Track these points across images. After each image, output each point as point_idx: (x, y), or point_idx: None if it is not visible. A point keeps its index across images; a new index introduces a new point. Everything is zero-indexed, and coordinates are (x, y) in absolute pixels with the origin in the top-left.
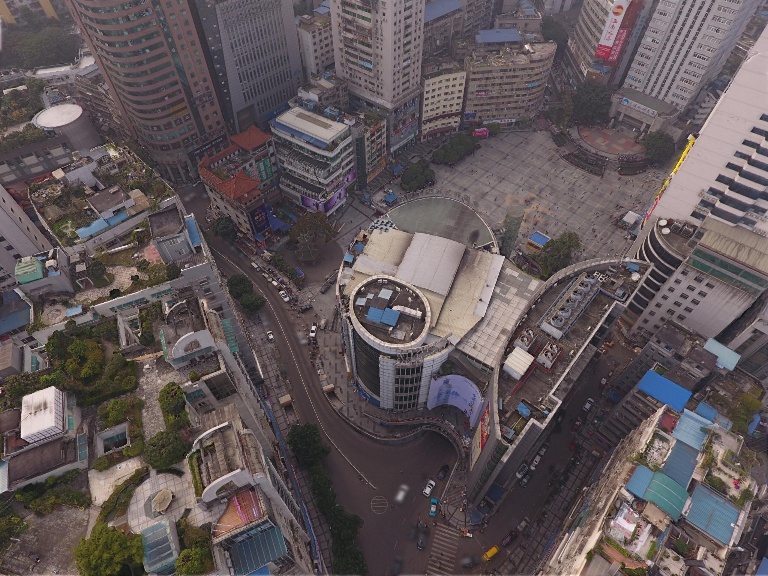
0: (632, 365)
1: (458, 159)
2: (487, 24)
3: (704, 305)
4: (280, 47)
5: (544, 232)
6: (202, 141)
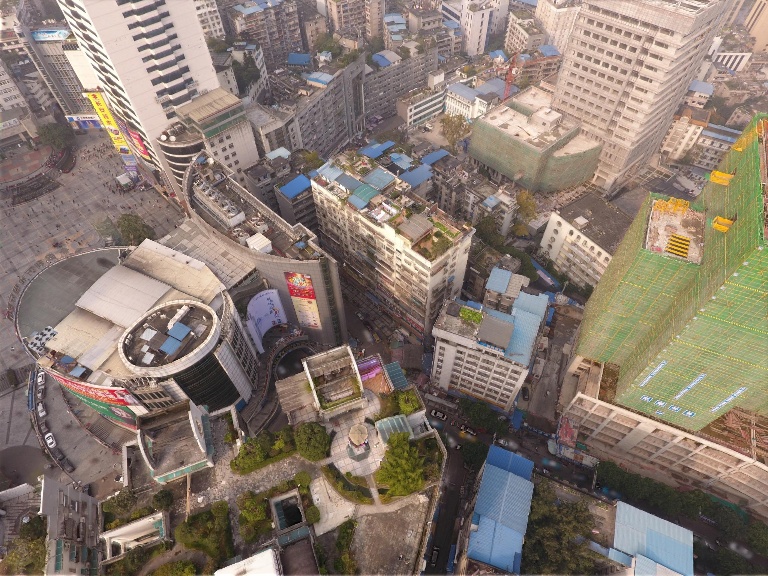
0: None
1: None
2: None
3: (238, 151)
4: None
5: None
6: None
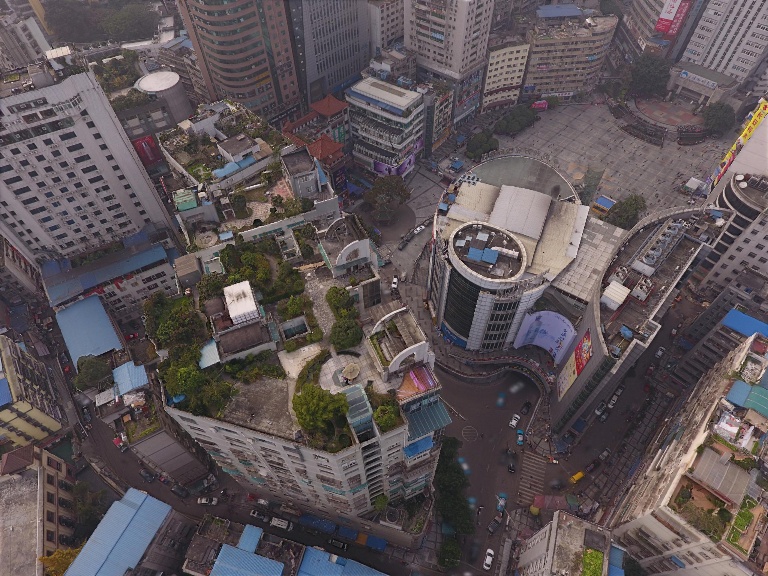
0: (708, 312)
1: (519, 130)
2: (543, 1)
3: None
4: (352, 21)
5: (608, 197)
6: (279, 110)
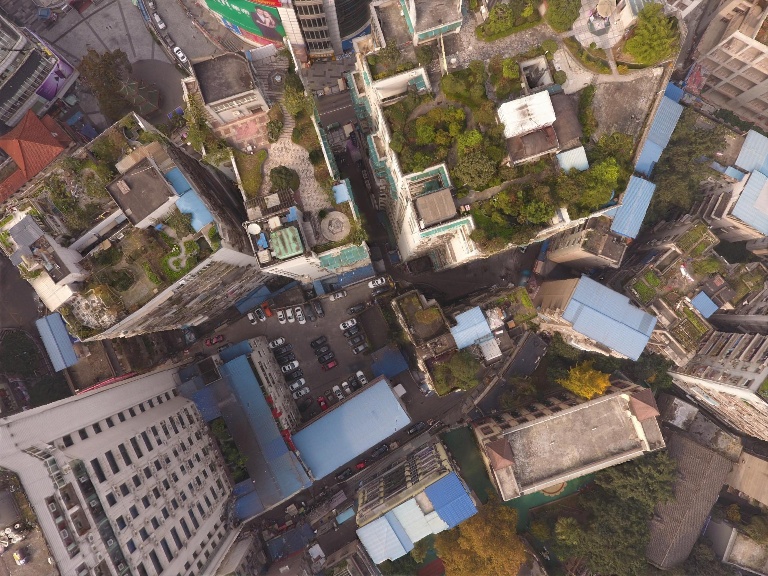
0: None
1: None
2: None
3: None
4: None
5: None
6: None
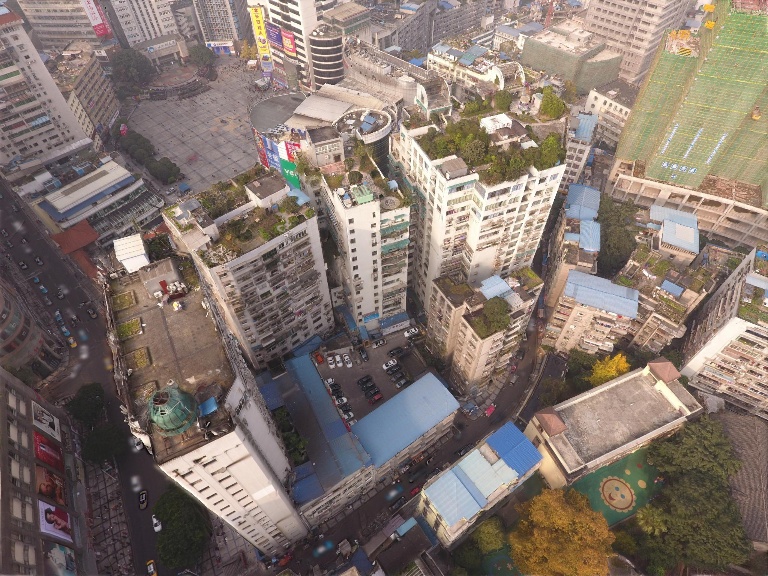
0: None
1: None
2: None
3: None
4: None
5: None
6: None
